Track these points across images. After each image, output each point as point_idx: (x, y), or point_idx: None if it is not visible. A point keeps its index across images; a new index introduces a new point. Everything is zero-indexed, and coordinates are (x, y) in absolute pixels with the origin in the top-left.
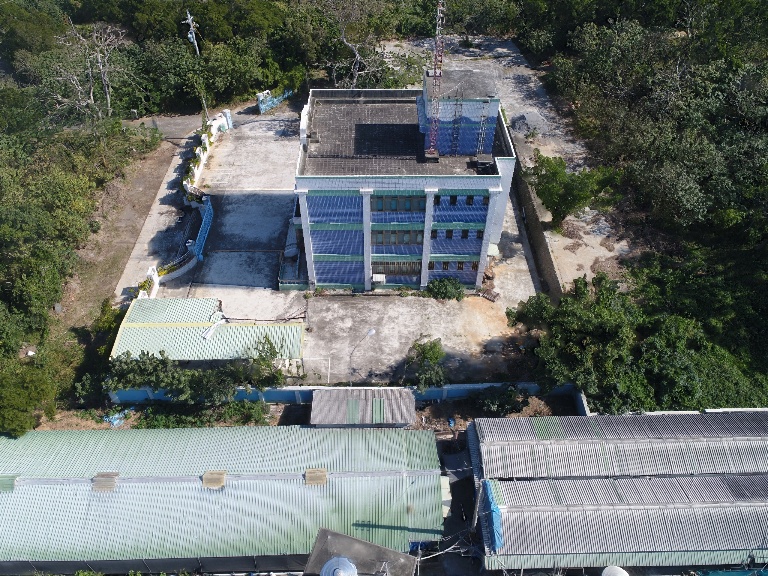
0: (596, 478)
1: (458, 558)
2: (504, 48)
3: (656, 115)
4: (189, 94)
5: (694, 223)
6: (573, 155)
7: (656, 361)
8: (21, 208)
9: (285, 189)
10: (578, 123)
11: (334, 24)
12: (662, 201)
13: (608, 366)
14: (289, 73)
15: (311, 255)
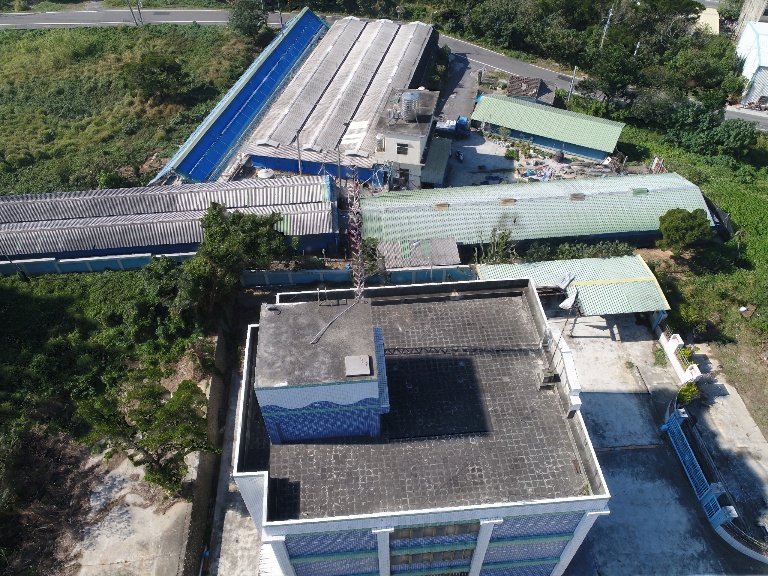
0: None
1: None
2: None
3: None
4: None
5: None
6: None
7: None
8: None
9: None
10: None
11: None
12: None
13: None
14: None
15: None
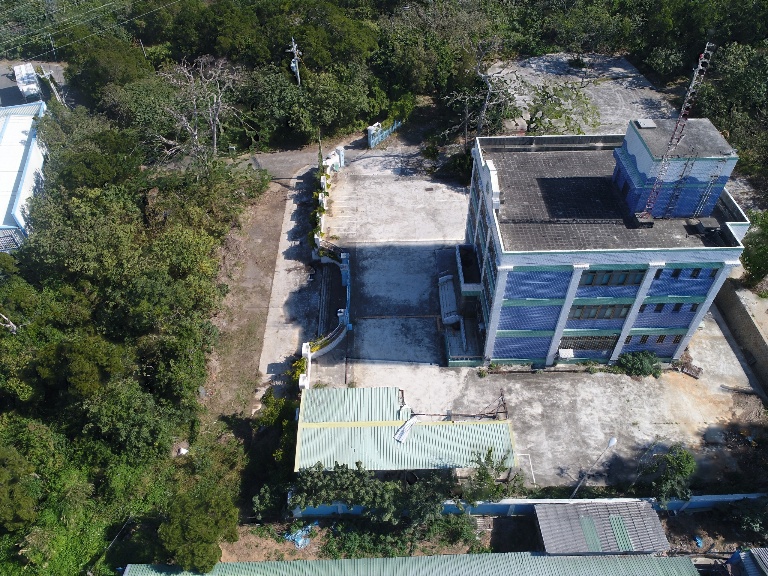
0: None
1: None
2: (620, 67)
3: None
4: (294, 129)
5: None
6: (738, 195)
7: None
8: (148, 274)
9: (422, 239)
10: None
11: (442, 47)
12: None
13: None
14: (398, 102)
15: (495, 332)
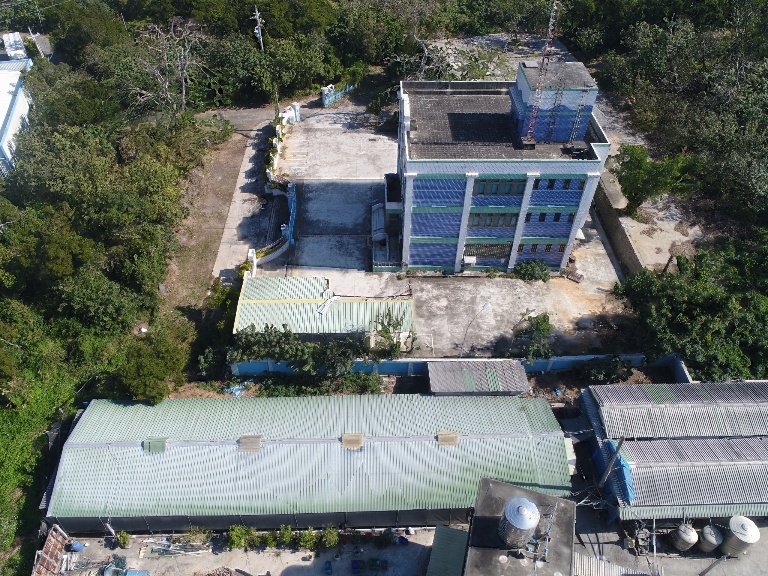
0: (711, 438)
1: (584, 513)
2: None
3: (717, 109)
4: (256, 88)
5: (765, 209)
6: None
7: (748, 334)
8: None
9: (361, 178)
10: (636, 117)
11: None
12: (731, 189)
13: (709, 338)
14: (350, 68)
15: (409, 237)
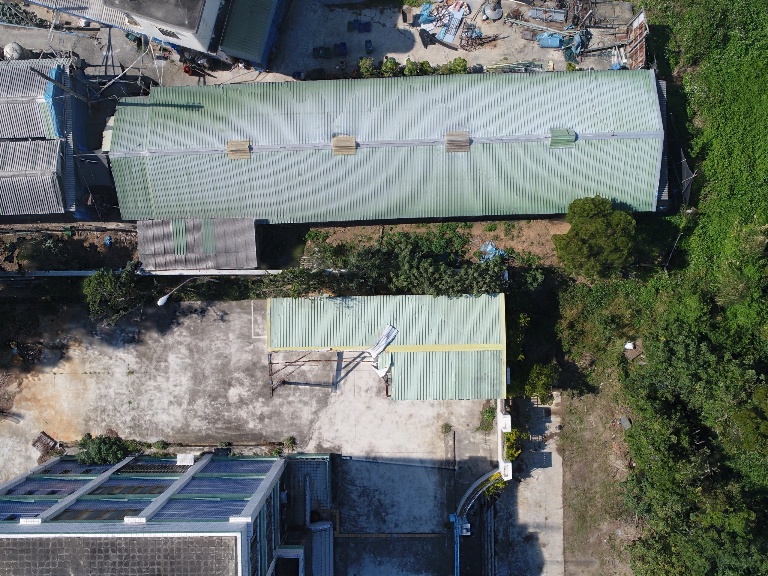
0: None
1: None
2: None
3: None
4: None
5: None
6: None
7: None
8: None
9: None
10: None
11: None
12: None
13: None
14: None
15: (268, 475)
